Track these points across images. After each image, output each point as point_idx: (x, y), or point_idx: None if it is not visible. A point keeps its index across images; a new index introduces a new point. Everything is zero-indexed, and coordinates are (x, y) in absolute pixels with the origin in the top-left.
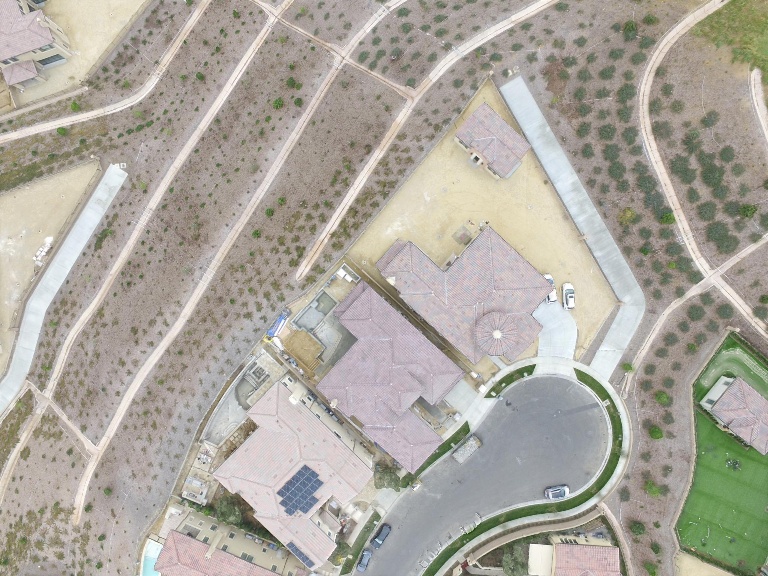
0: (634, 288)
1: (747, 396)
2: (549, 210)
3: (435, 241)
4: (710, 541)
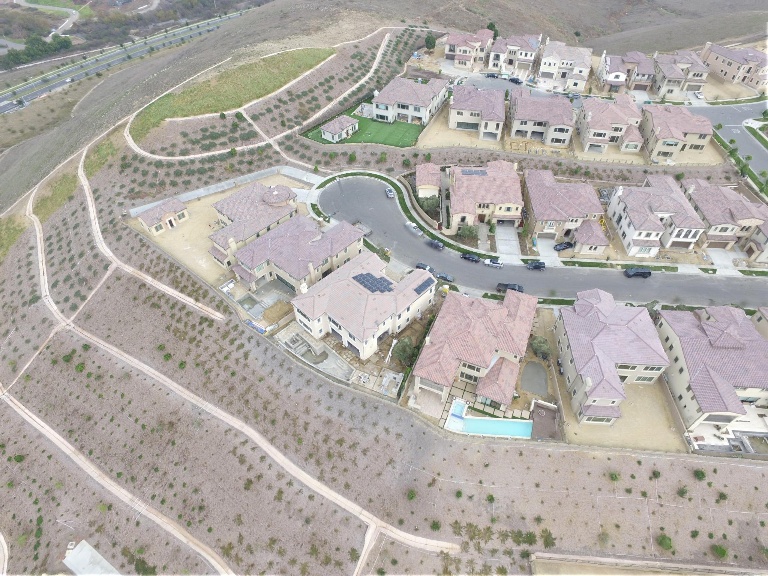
0: (272, 169)
1: (328, 124)
2: (217, 199)
3: None
4: (410, 139)
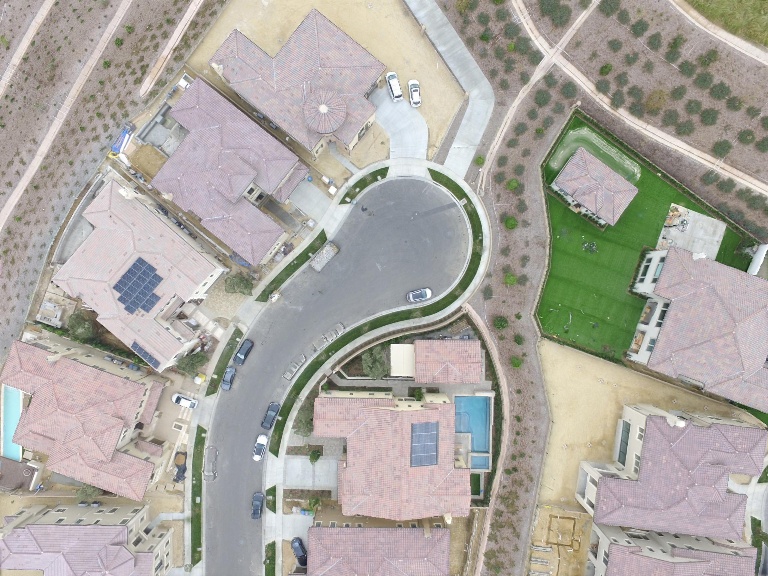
0: (481, 81)
1: (589, 164)
2: (389, 7)
3: (276, 46)
4: (573, 328)
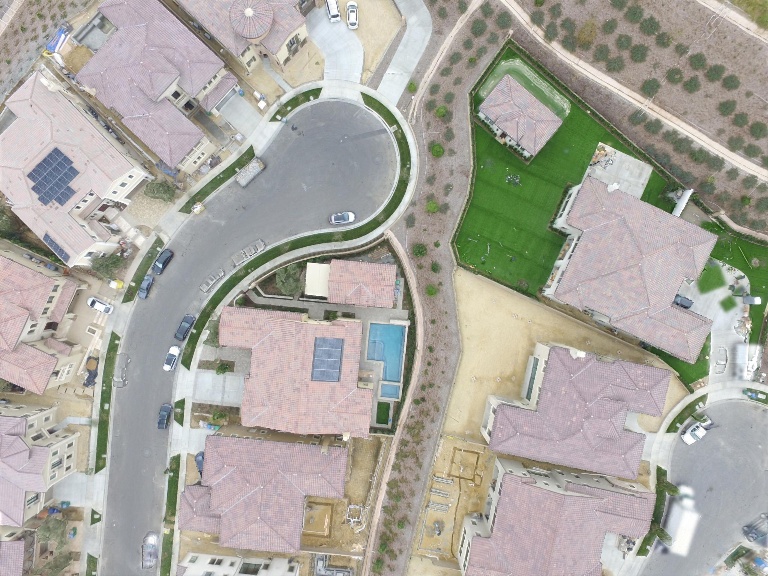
0: (420, 8)
1: (514, 91)
2: None
3: None
4: (490, 259)
